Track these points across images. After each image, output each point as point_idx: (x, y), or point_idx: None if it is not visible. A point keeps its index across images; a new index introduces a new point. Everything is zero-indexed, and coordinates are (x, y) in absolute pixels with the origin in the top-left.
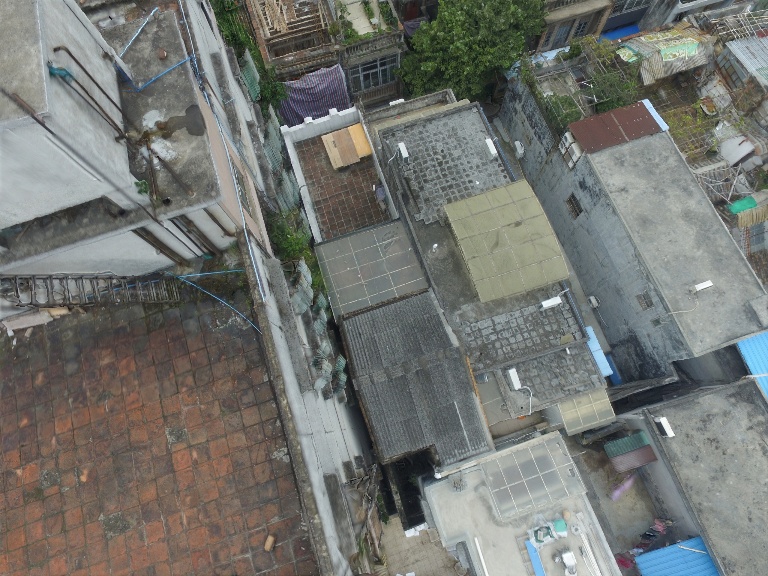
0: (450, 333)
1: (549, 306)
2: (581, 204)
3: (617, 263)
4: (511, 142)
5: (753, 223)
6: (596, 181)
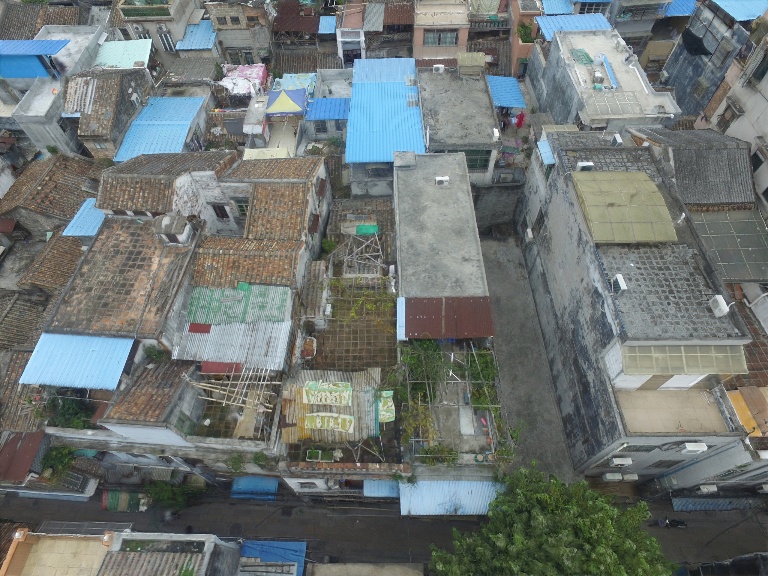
0: (672, 160)
1: None
2: None
3: None
4: None
5: None
6: None
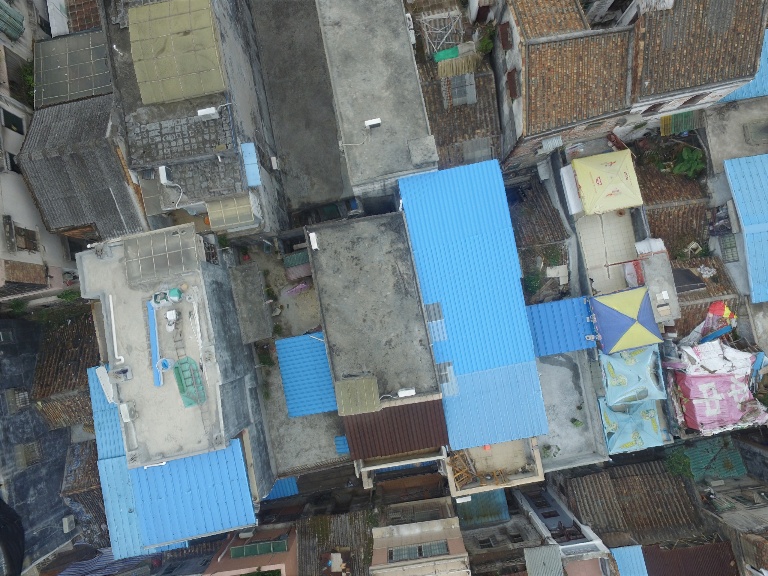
0: (109, 127)
1: (203, 115)
2: None
3: None
4: None
5: (454, 74)
6: None
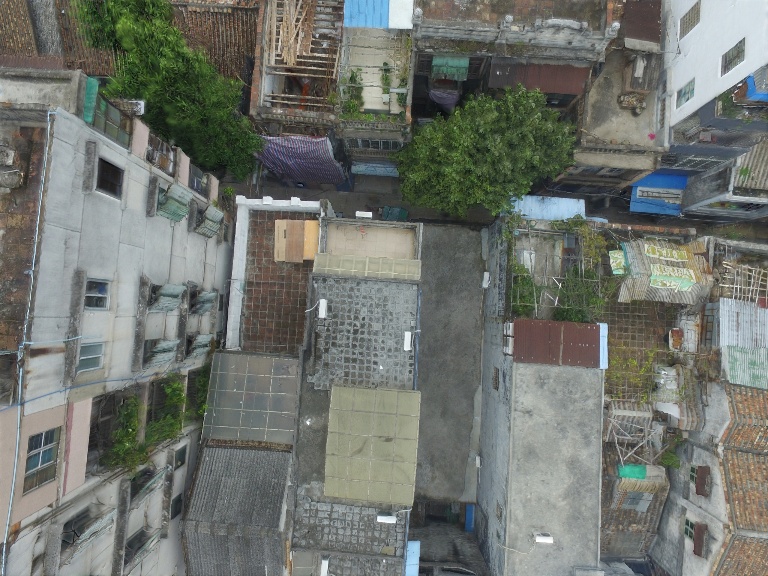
0: (283, 512)
1: None
2: (499, 386)
3: (498, 462)
4: (487, 262)
5: (633, 490)
6: (510, 390)
